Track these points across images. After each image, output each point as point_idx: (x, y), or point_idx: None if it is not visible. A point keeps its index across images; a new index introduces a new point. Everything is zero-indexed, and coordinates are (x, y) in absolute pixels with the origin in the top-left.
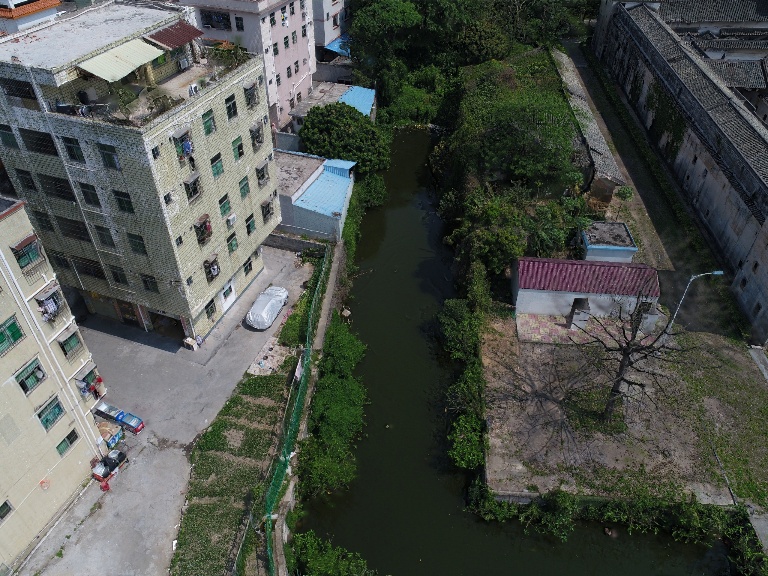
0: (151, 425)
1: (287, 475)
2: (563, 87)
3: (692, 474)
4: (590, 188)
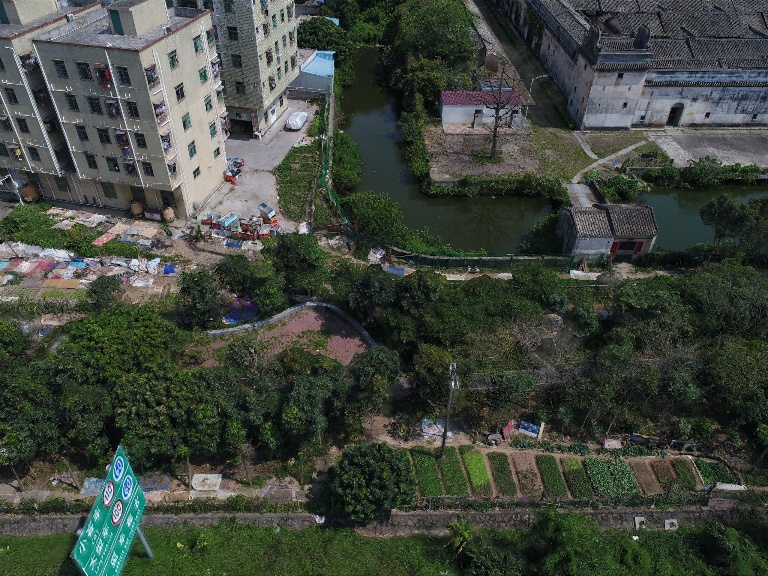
0: (247, 165)
1: (327, 178)
2: (467, 11)
3: (536, 174)
4: (484, 63)
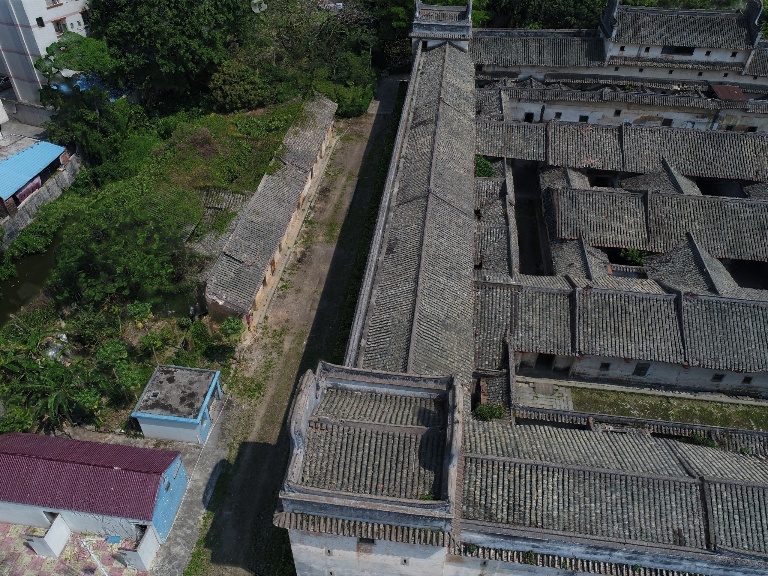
0: None
1: None
2: (273, 155)
3: None
4: (208, 311)
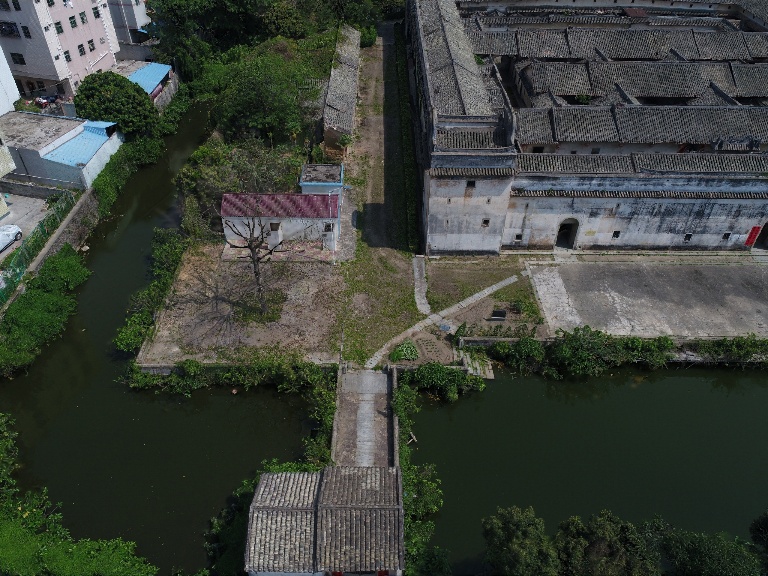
0: None
1: None
2: (333, 57)
3: (316, 347)
4: (323, 138)
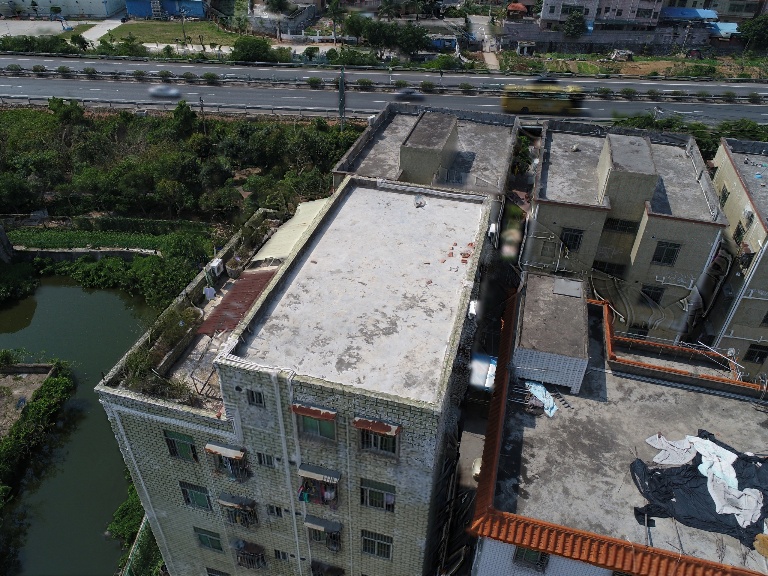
0: None
1: None
2: None
3: None
4: None
